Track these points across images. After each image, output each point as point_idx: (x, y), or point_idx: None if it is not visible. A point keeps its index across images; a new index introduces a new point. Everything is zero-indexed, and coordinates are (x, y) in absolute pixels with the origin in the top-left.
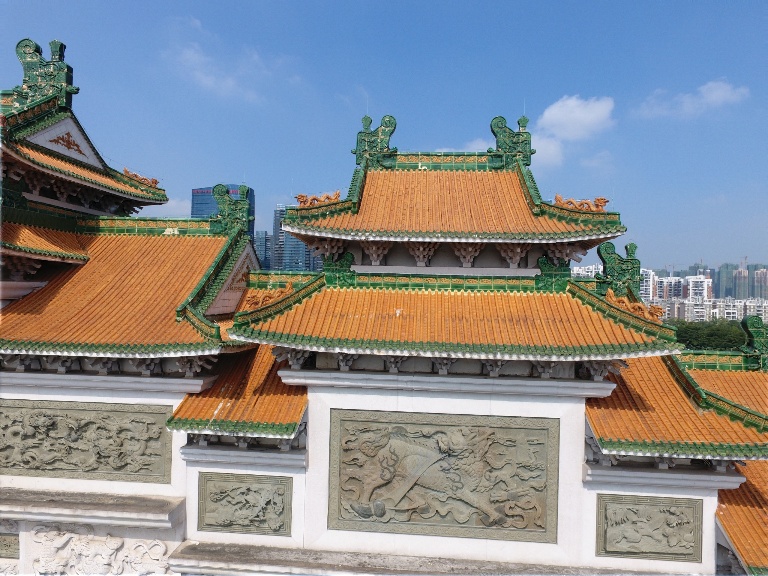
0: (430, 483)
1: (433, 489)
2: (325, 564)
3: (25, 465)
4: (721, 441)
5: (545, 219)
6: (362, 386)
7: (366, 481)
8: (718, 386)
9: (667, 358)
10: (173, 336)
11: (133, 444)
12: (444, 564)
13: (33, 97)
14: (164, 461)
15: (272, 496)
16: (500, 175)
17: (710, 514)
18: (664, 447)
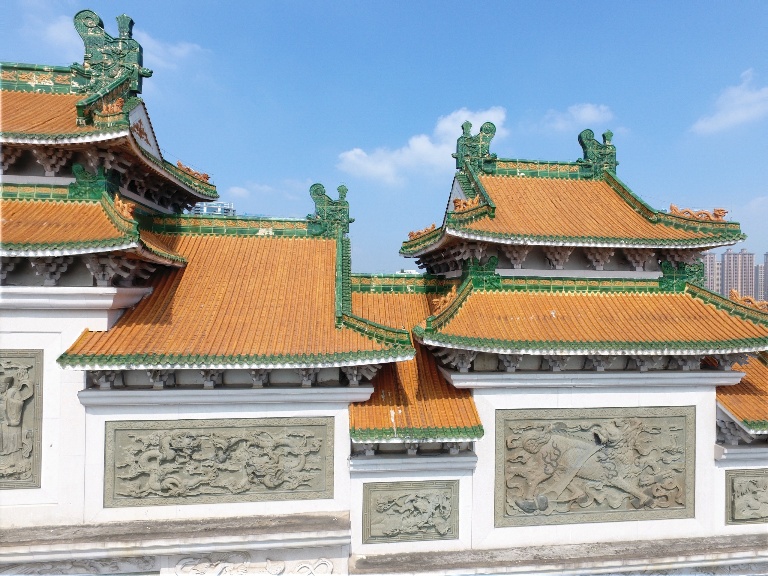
0: (589, 474)
1: (590, 479)
2: (505, 561)
3: (164, 493)
4: None
5: (662, 226)
6: (529, 386)
7: (530, 477)
8: None
9: None
10: (345, 343)
11: (290, 460)
12: (606, 548)
13: (97, 77)
14: (325, 475)
15: (441, 500)
16: (592, 184)
17: None
18: None
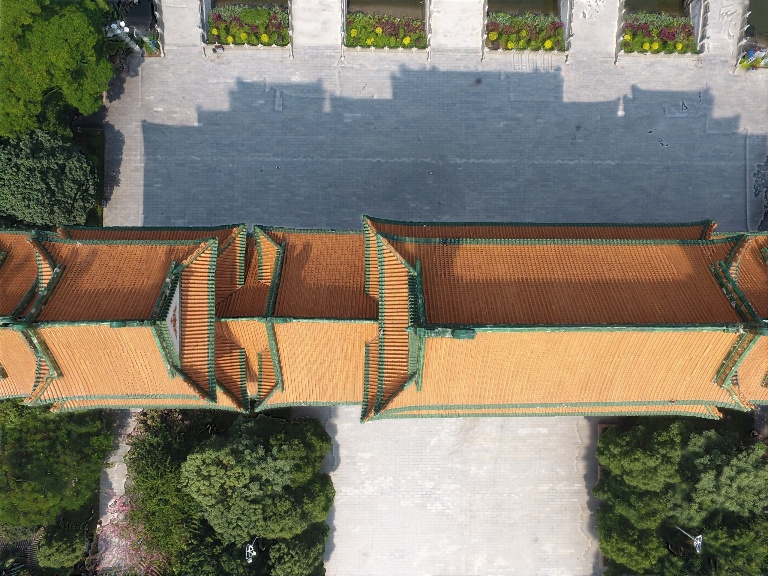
0: None
1: None
2: None
3: None
4: None
5: None
6: None
7: None
8: None
9: None
10: (760, 394)
11: None
12: None
13: None
14: None
15: None
16: None
17: None
18: None
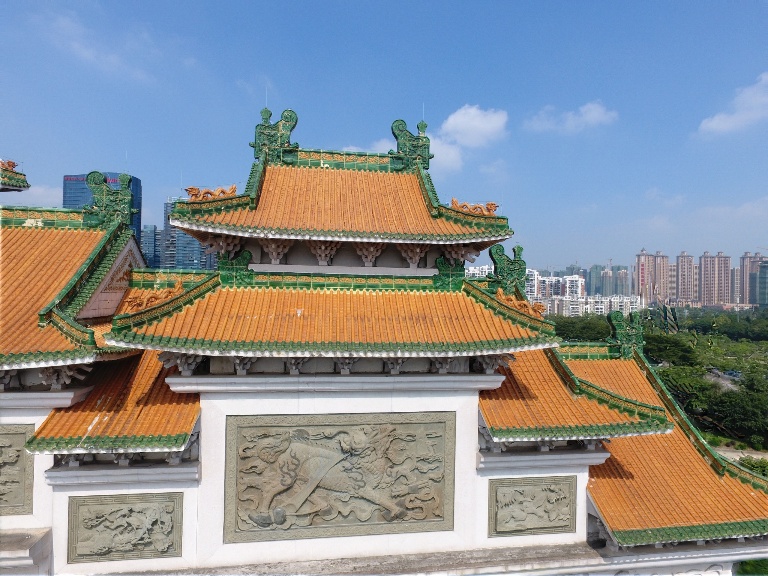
0: (332, 484)
1: (335, 490)
2: None
3: None
4: (591, 423)
5: (443, 221)
6: (261, 390)
7: (265, 489)
8: (589, 374)
9: (548, 350)
10: (35, 344)
11: None
12: (346, 564)
13: None
14: (23, 488)
15: (159, 515)
16: (401, 177)
17: (582, 488)
18: (545, 431)
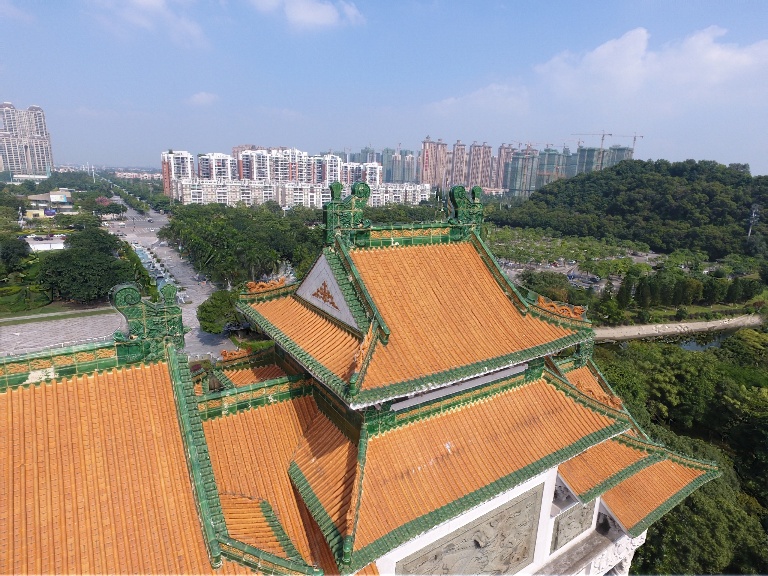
0: (468, 574)
1: (468, 575)
2: None
3: None
4: (624, 465)
5: (531, 318)
6: None
7: None
8: None
9: None
10: None
11: None
12: None
13: None
14: None
15: None
16: (461, 249)
17: (599, 498)
18: (609, 486)
